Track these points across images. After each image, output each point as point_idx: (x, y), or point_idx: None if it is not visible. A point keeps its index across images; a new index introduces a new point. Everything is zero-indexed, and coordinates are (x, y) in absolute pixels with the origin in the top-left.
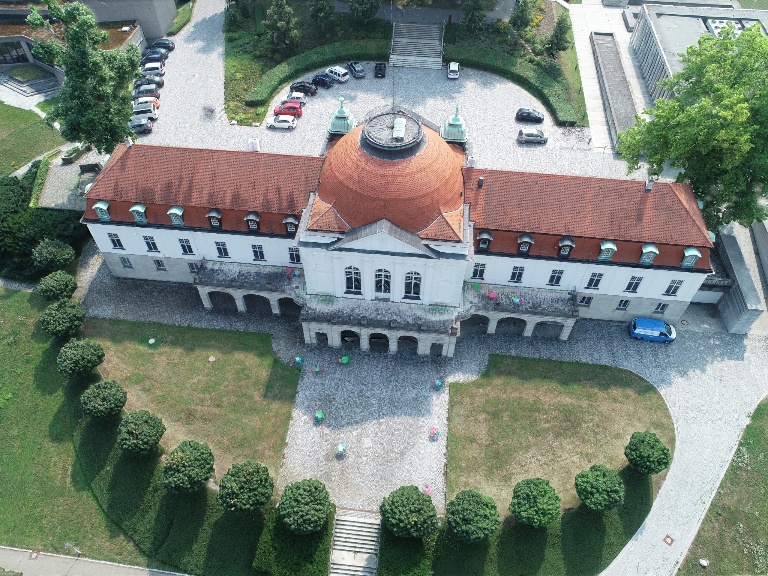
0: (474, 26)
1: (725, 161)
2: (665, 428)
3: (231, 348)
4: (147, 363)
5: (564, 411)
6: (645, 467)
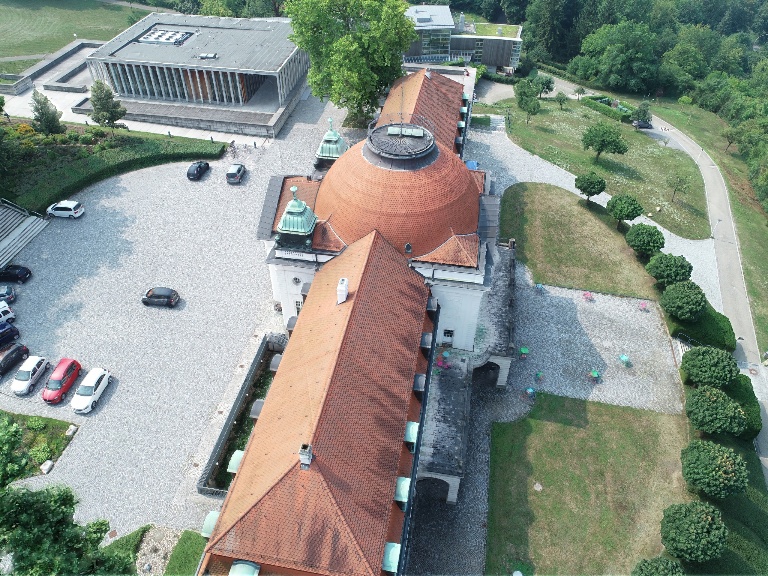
0: (1, 169)
1: (405, 45)
2: (549, 187)
3: (519, 465)
4: (557, 575)
5: (548, 226)
6: (604, 185)
